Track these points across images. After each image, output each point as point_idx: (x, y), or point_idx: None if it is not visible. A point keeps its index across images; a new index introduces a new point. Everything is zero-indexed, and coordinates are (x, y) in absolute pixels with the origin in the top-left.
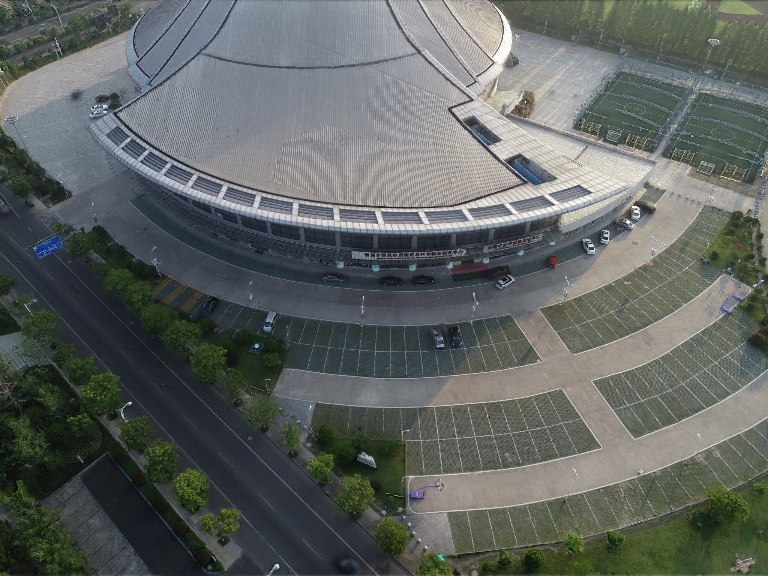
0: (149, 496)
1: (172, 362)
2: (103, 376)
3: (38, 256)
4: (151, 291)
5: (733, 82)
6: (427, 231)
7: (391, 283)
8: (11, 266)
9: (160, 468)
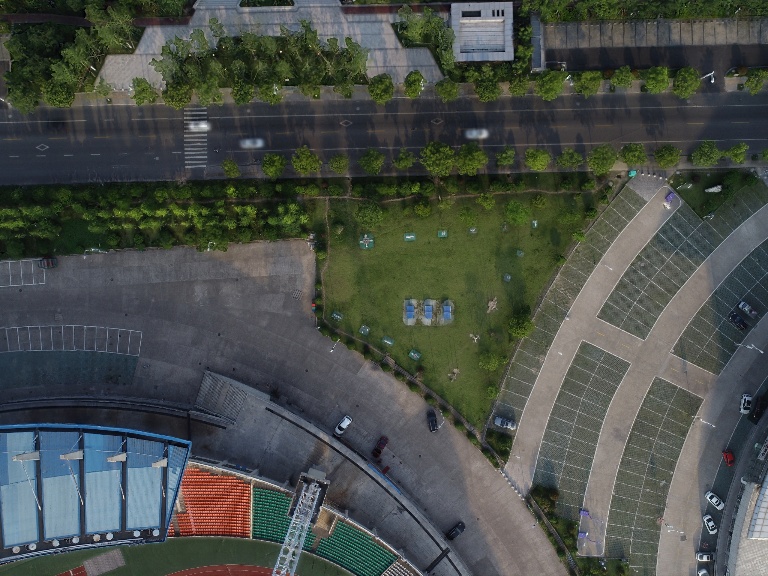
0: None
1: None
2: None
3: None
4: None
5: None
6: None
7: None
8: None
9: None
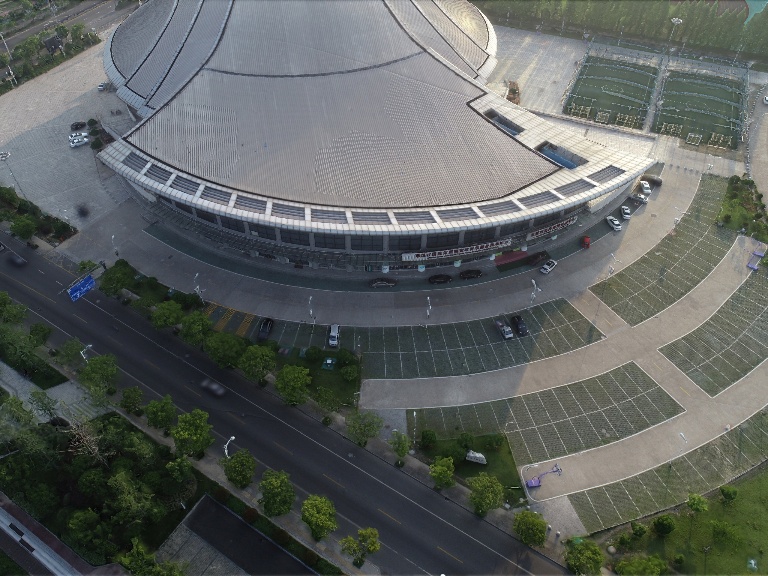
0: (266, 531)
1: (244, 390)
2: (191, 414)
3: (72, 299)
4: None
5: (690, 57)
6: (486, 225)
7: (441, 281)
8: (33, 314)
9: (279, 500)
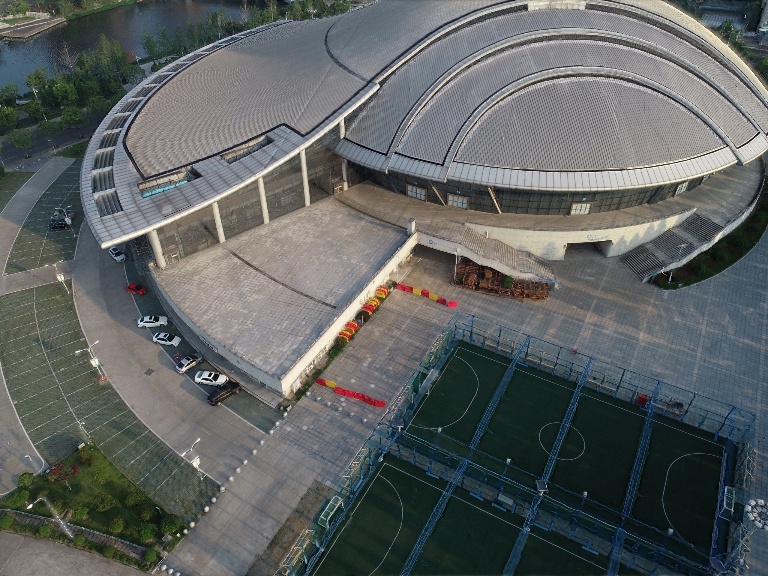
0: (6, 132)
1: None
2: None
3: None
4: None
5: None
6: None
7: None
8: None
9: None
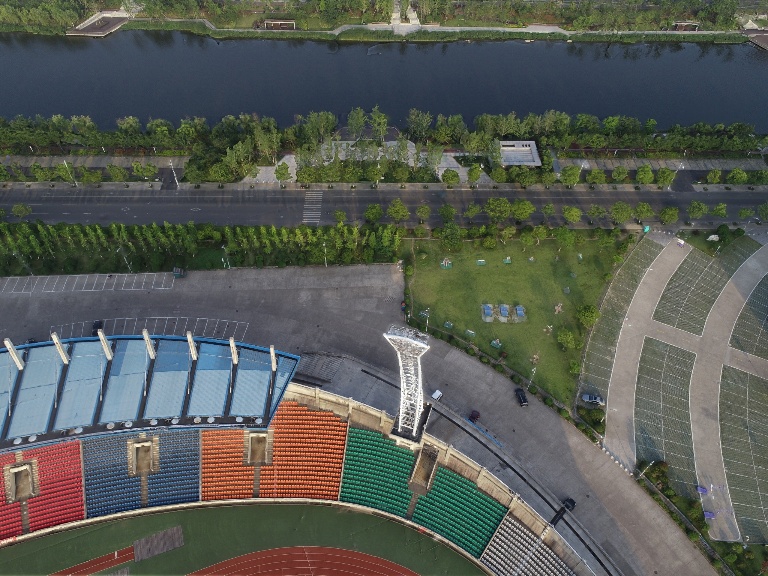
0: None
1: None
2: None
3: None
4: None
5: None
6: None
7: None
8: None
9: None
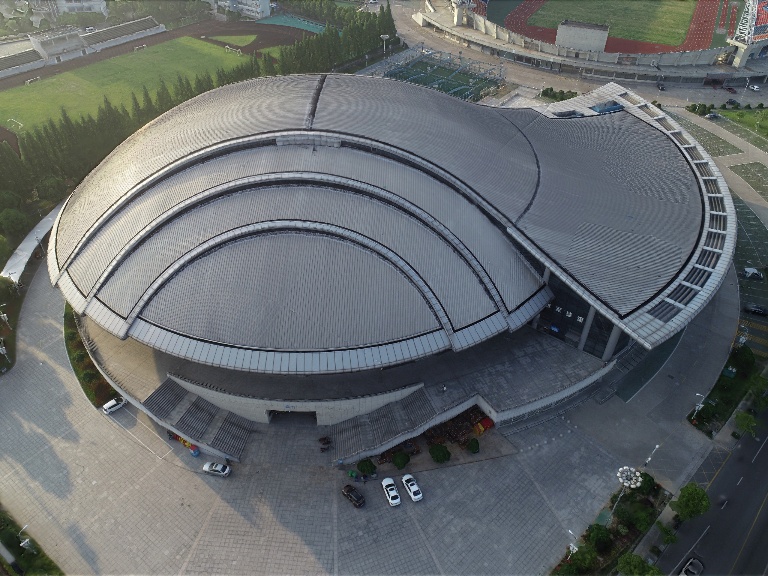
0: None
1: None
2: None
3: None
4: (761, 356)
5: (371, 64)
6: None
7: None
8: None
9: None
